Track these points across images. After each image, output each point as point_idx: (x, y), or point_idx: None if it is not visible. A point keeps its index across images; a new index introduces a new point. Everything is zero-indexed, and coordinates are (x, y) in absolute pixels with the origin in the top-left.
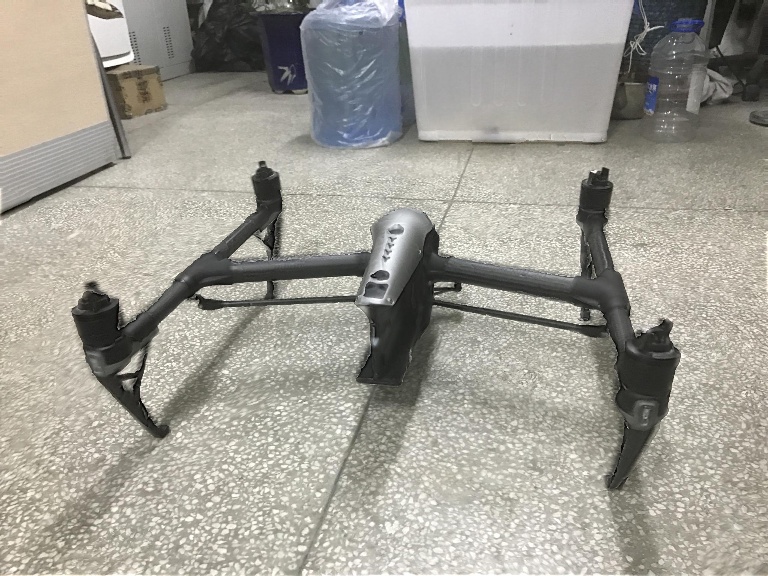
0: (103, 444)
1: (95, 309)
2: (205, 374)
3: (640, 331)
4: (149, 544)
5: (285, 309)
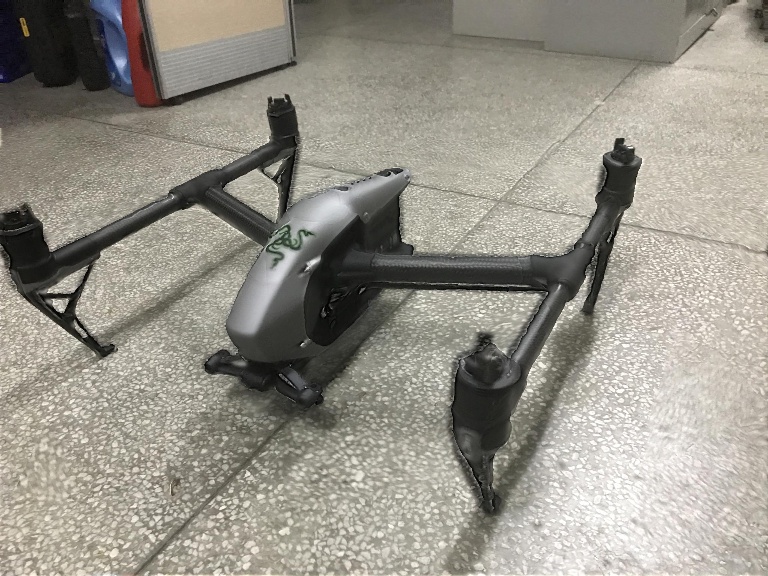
0: (638, 310)
1: None
2: (566, 366)
3: (86, 324)
4: (564, 249)
5: (466, 467)
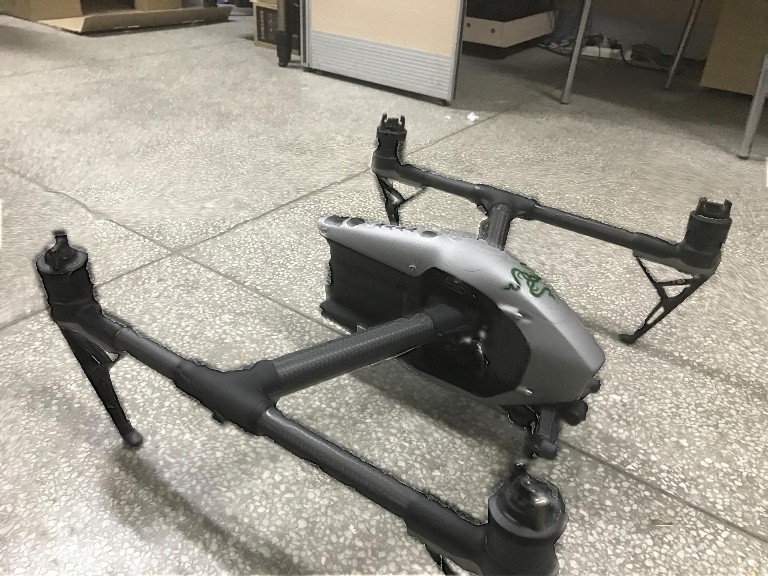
0: None
1: (379, 126)
2: None
3: None
4: None
5: None
